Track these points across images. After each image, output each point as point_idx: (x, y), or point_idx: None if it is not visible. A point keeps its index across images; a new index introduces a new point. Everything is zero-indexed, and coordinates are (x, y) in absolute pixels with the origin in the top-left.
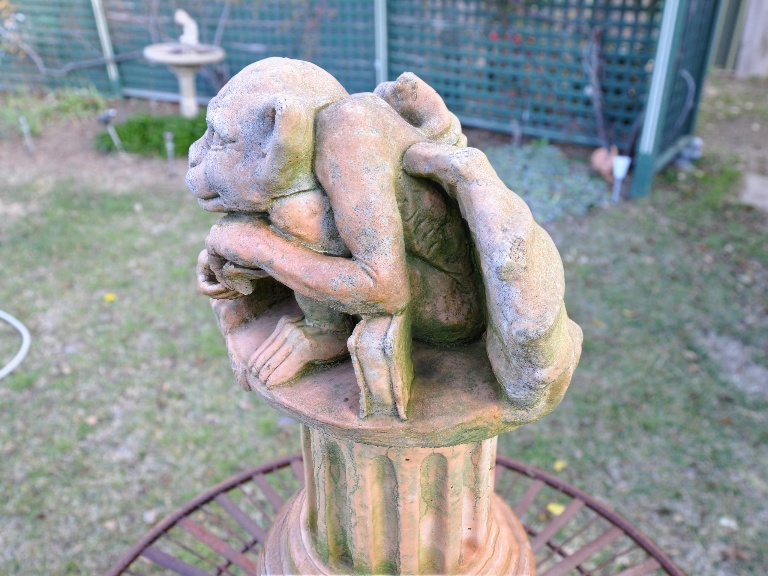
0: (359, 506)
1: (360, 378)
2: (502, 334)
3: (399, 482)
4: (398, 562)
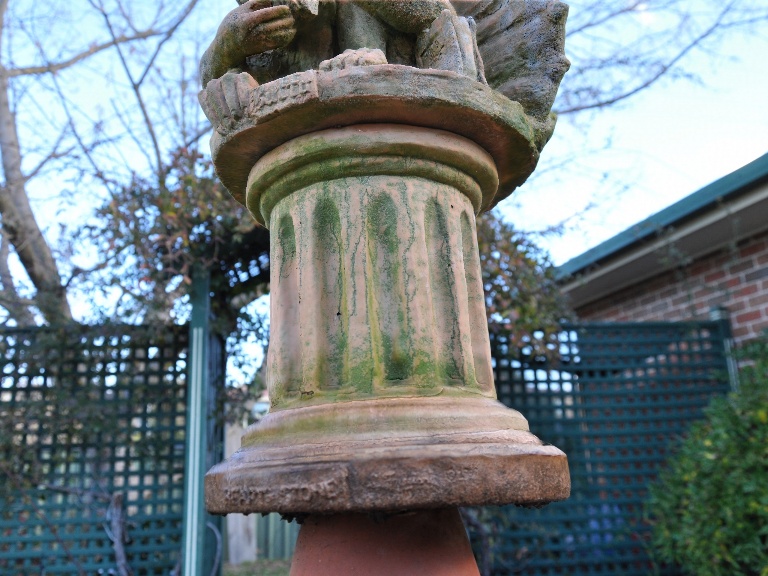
0: (417, 265)
1: (457, 40)
2: (528, 39)
3: (450, 231)
4: (459, 349)
